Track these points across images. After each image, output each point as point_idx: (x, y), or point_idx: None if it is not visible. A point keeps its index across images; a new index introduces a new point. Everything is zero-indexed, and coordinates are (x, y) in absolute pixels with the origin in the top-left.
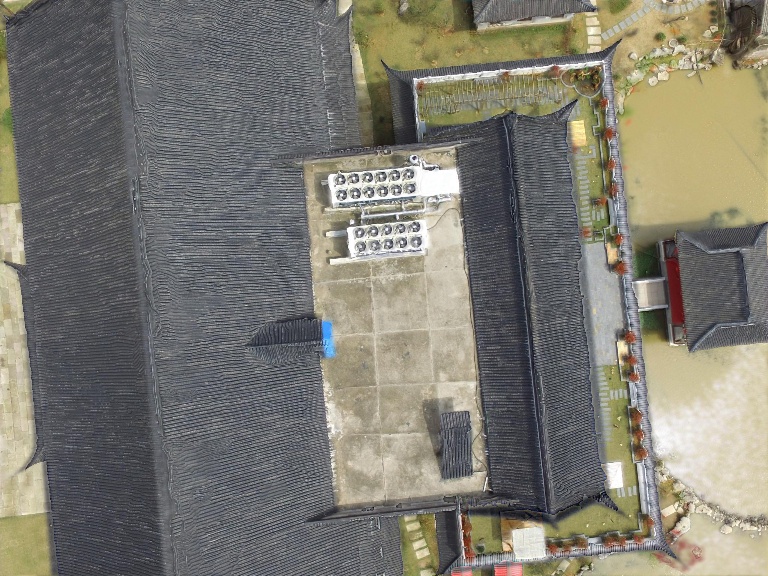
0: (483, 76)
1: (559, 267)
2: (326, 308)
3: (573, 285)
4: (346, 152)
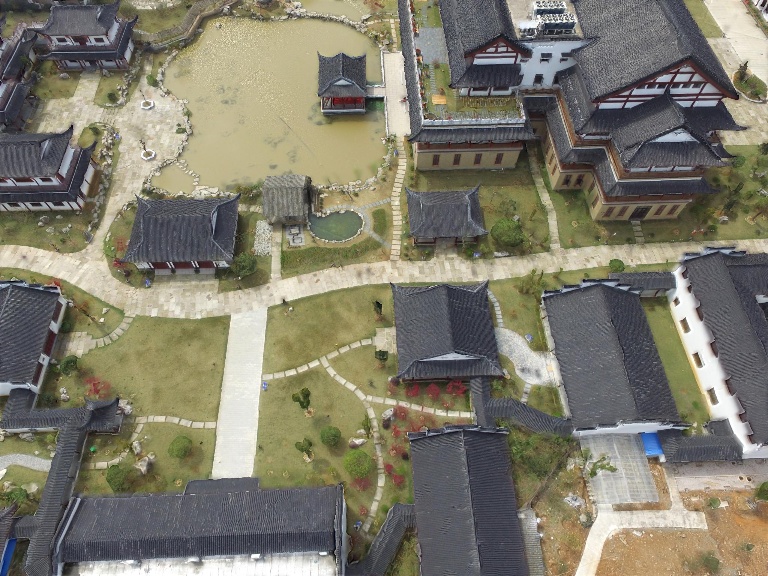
0: (487, 122)
1: (472, 5)
2: (568, 5)
3: (464, 5)
4: (569, 40)
